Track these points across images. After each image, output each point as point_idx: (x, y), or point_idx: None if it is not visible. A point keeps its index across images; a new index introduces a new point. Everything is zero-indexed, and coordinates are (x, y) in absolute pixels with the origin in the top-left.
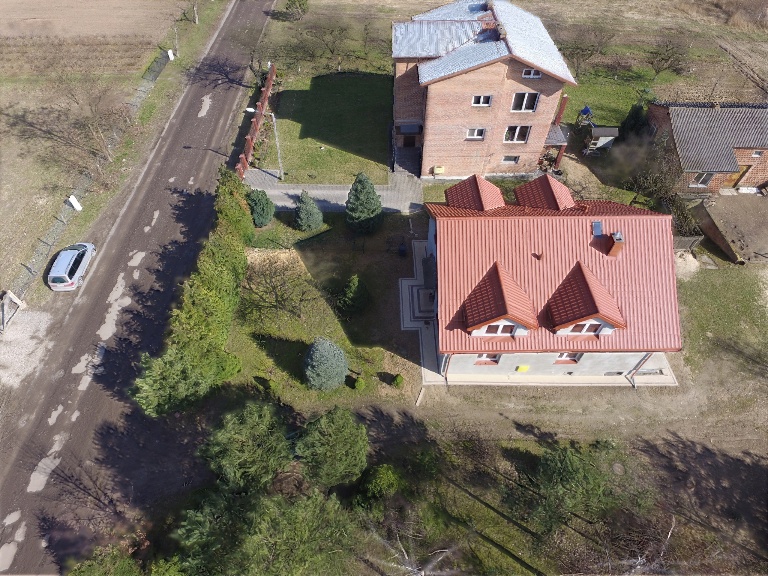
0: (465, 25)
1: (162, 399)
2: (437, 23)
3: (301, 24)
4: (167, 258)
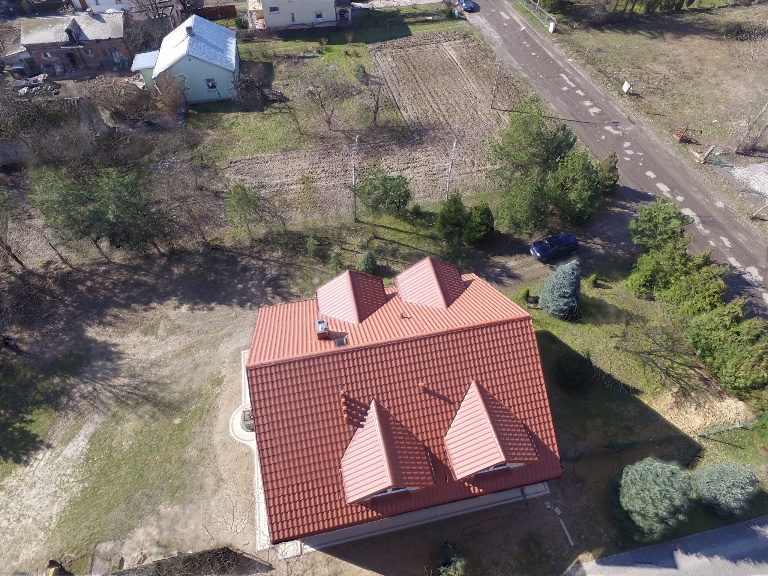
0: None
1: None
2: None
3: None
4: None
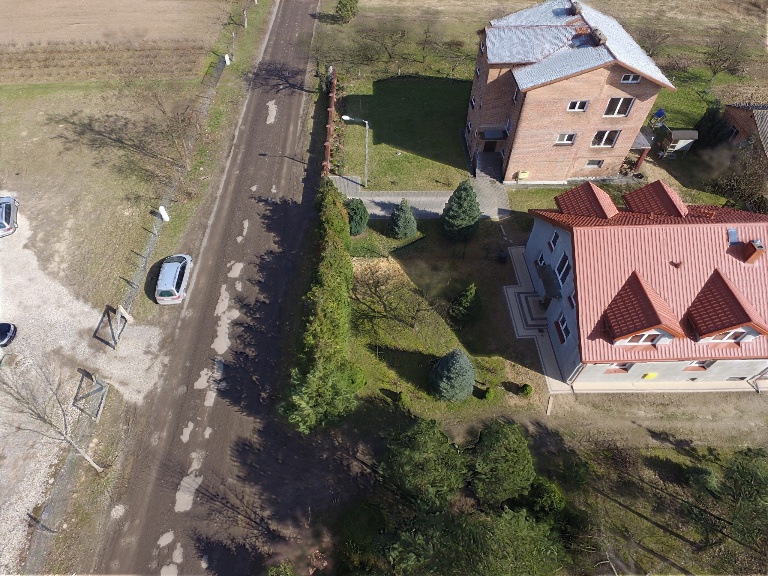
0: (558, 30)
1: (320, 416)
2: (530, 28)
3: (351, 27)
4: (266, 269)
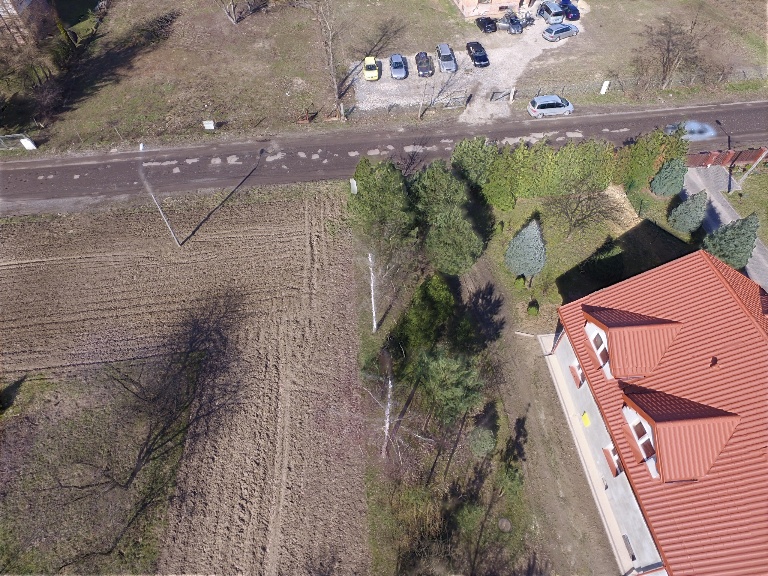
0: None
1: (459, 156)
2: None
3: None
4: None
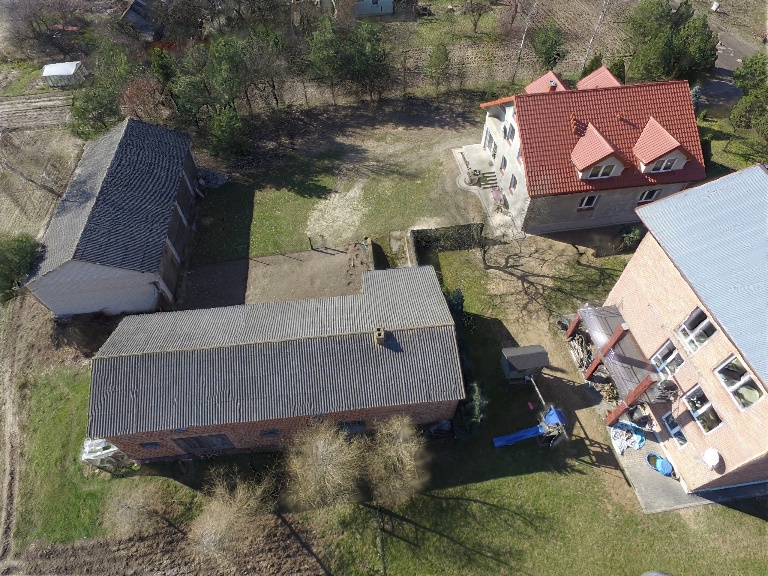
0: None
1: None
2: None
3: None
4: None
